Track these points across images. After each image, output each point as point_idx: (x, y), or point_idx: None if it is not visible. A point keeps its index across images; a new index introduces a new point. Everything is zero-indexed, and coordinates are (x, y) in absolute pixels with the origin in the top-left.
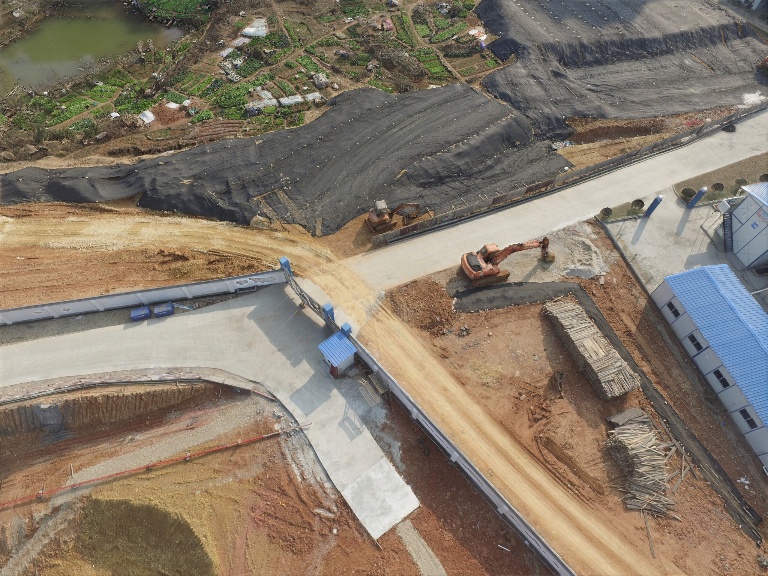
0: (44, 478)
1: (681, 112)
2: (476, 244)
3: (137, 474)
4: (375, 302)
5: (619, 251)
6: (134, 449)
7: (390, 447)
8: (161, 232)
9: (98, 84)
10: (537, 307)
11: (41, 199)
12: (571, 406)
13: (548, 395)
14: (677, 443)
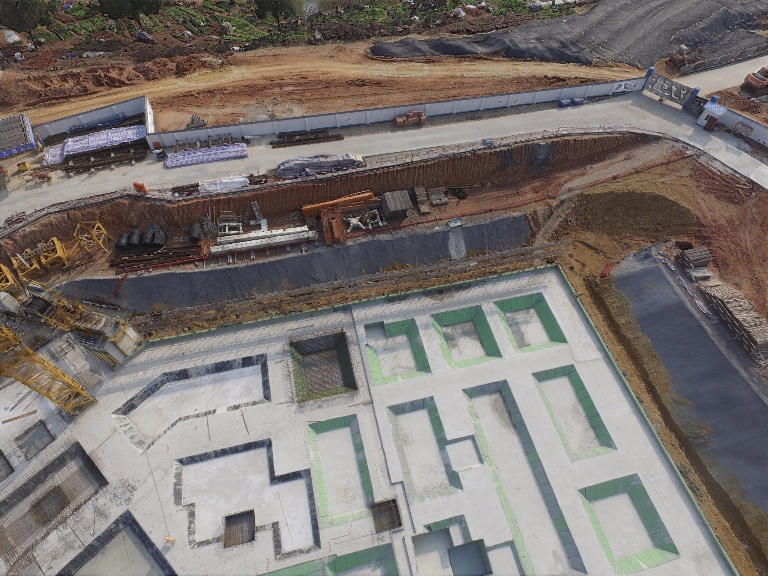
0: (545, 188)
1: None
2: (741, 76)
3: (608, 181)
4: None
5: None
6: (596, 171)
7: (762, 160)
8: (534, 69)
9: (367, 7)
10: None
11: (434, 54)
12: None
13: None
14: None
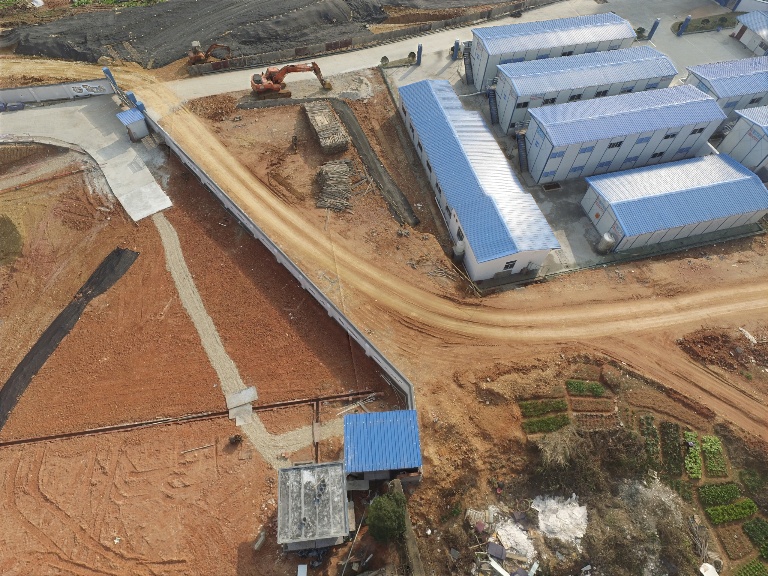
0: None
1: (481, 4)
2: None
3: None
4: (179, 105)
5: (386, 84)
6: None
7: (161, 177)
8: (28, 67)
9: None
10: (299, 107)
11: None
12: (301, 158)
13: (287, 152)
14: (369, 177)
